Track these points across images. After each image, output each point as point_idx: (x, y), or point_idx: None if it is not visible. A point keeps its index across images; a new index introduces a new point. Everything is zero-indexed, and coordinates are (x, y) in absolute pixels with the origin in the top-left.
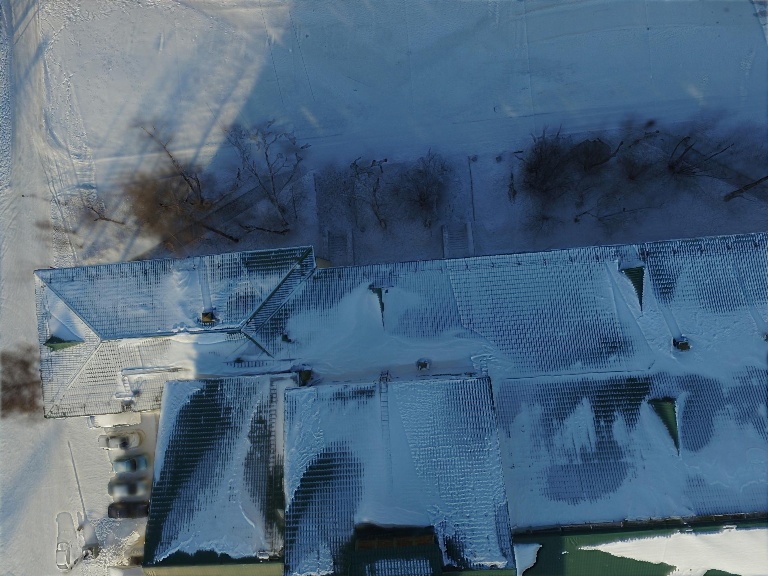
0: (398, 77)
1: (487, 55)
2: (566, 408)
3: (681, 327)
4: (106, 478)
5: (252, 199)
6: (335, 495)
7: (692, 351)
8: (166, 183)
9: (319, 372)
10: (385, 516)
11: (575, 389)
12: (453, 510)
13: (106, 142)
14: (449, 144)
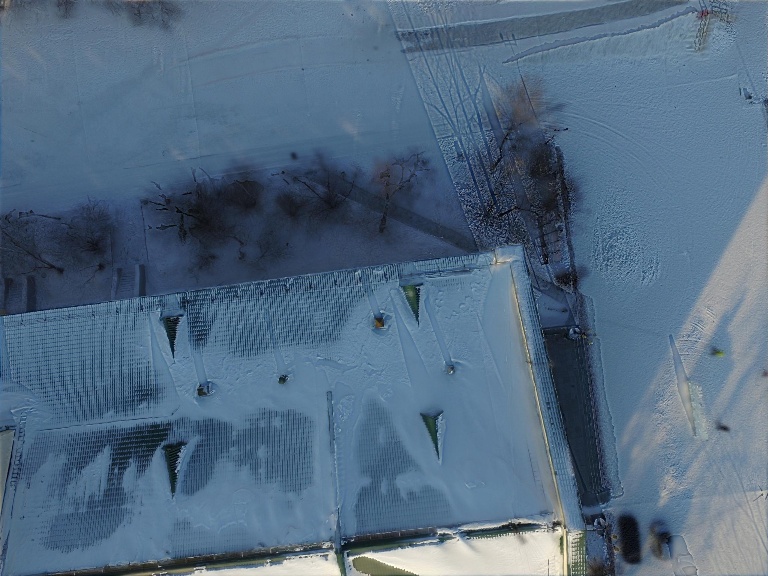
0: (71, 127)
1: (155, 101)
2: (88, 457)
3: (208, 372)
4: None
5: None
6: None
7: (214, 395)
8: None
9: None
10: None
11: (102, 437)
12: None
13: None
14: (122, 189)
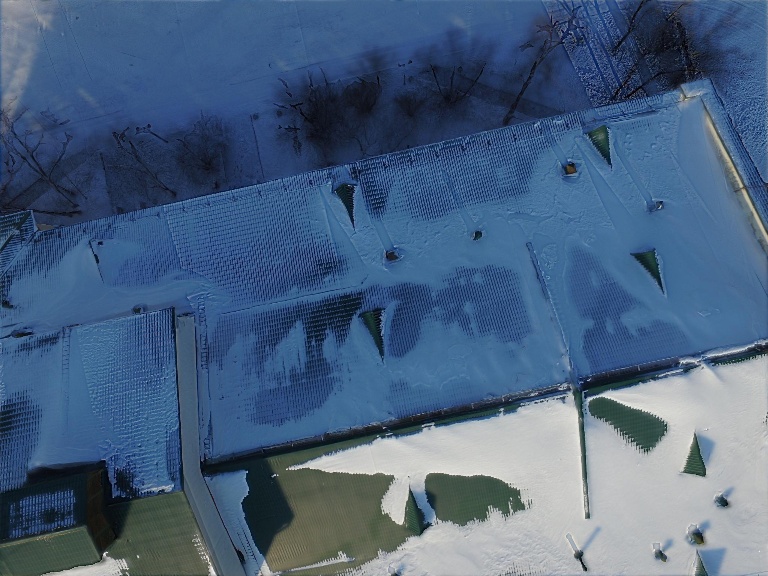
0: (171, 46)
1: (256, 13)
2: (279, 333)
3: (393, 238)
4: None
5: (43, 186)
6: (11, 445)
7: (403, 260)
8: None
9: None
10: (54, 457)
11: (290, 314)
12: (125, 442)
13: None
14: (230, 106)
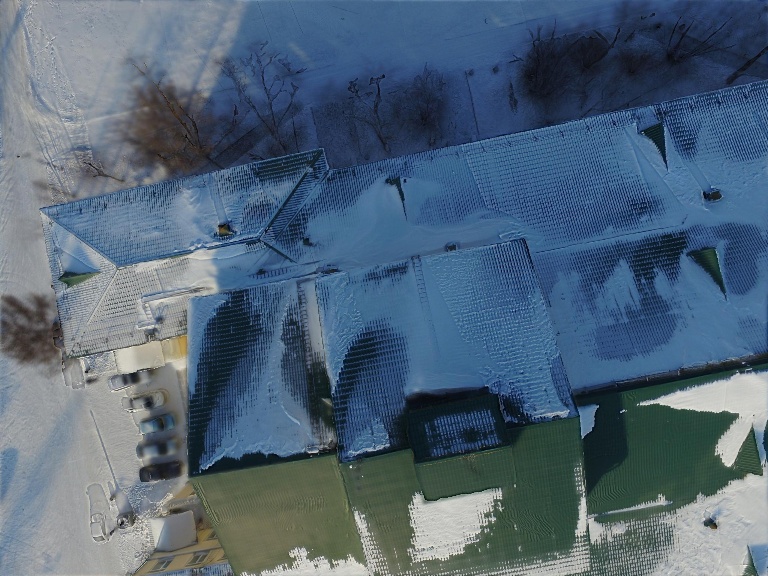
0: (385, 0)
1: None
2: (604, 271)
3: (709, 179)
4: (133, 443)
5: (251, 141)
6: (381, 371)
7: (724, 201)
8: (162, 135)
9: None
10: (436, 382)
11: (610, 253)
12: (505, 369)
13: (96, 101)
14: (444, 61)
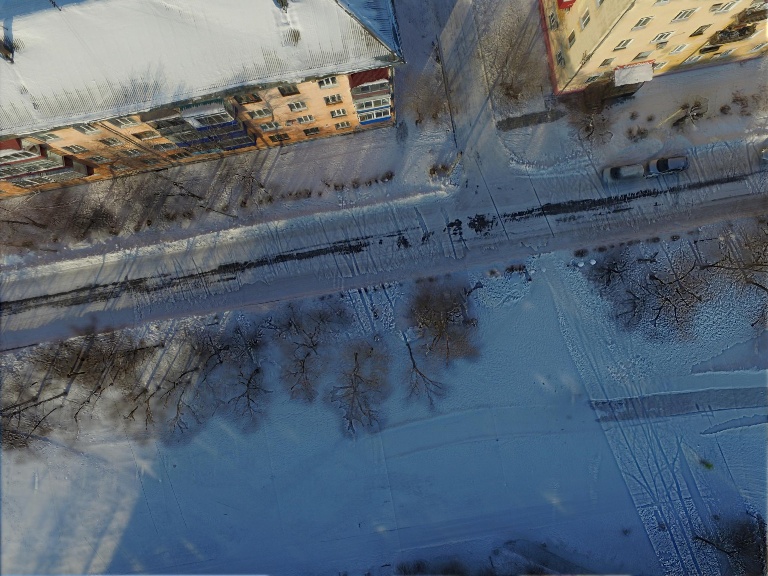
0: (265, 501)
1: (348, 473)
2: None
3: None
4: None
5: None
6: None
7: None
8: None
9: None
10: None
11: None
12: None
13: None
14: (319, 562)
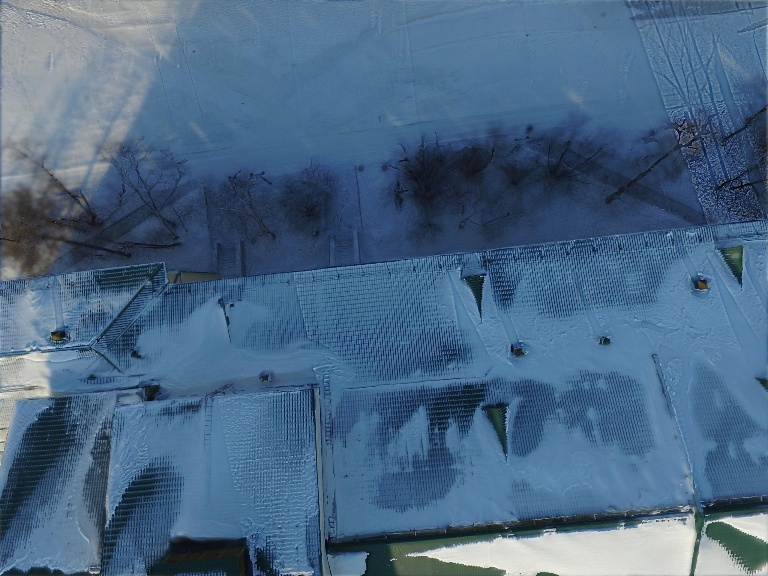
0: (284, 89)
1: (371, 65)
2: (403, 416)
3: (519, 333)
4: None
5: (145, 214)
6: (154, 510)
7: (528, 356)
8: (60, 200)
9: (166, 387)
10: (198, 529)
11: (413, 397)
12: (266, 522)
13: (0, 161)
14: (336, 154)
